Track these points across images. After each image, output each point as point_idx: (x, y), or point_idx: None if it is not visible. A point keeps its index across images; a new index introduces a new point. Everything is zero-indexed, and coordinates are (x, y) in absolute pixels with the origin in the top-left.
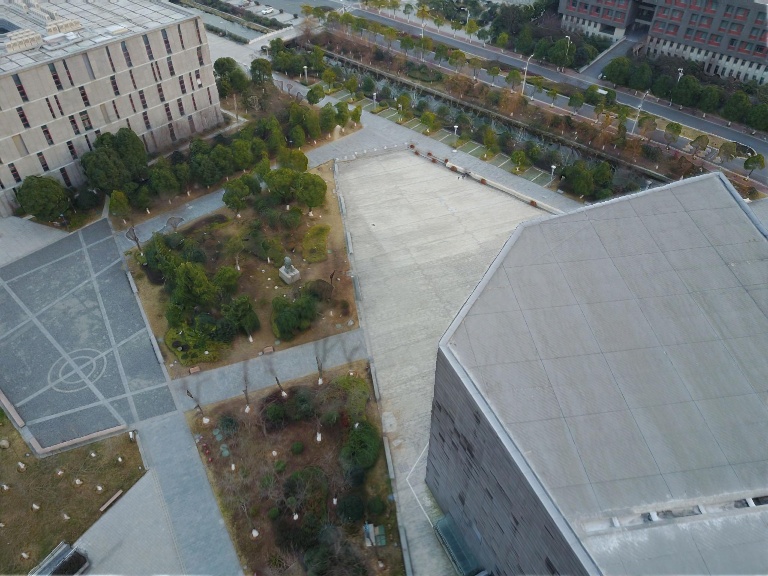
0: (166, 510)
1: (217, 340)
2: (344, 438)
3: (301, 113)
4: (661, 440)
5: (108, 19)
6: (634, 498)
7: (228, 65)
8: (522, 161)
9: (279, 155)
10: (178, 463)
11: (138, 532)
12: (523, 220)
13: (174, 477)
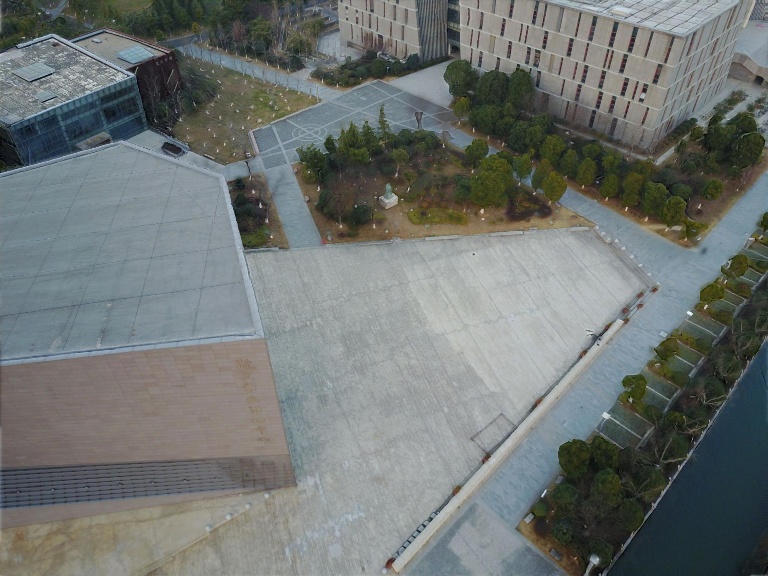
0: None
1: None
2: None
3: None
4: None
5: (650, 7)
6: None
7: (738, 122)
8: (633, 392)
9: None
10: (226, 174)
11: None
12: (498, 384)
13: None
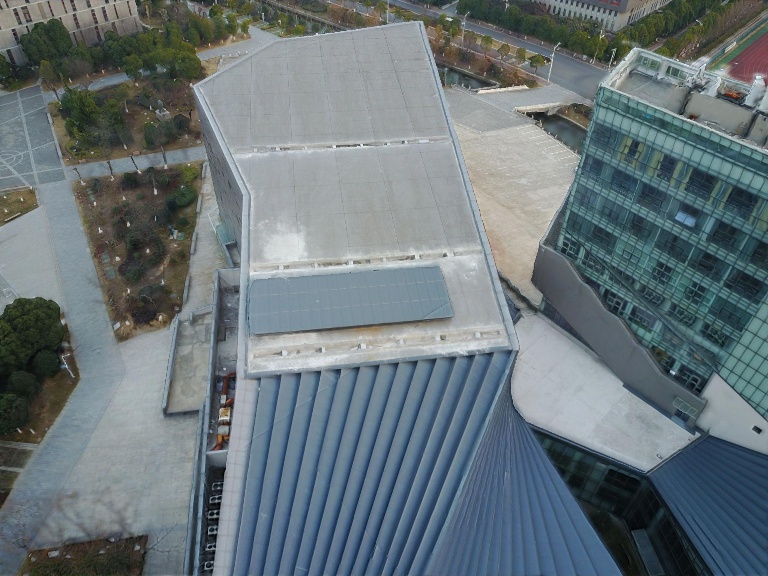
0: (47, 223)
1: (101, 146)
2: (172, 192)
3: (198, 21)
4: (300, 124)
5: None
6: (270, 142)
7: None
8: None
9: (171, 44)
10: (60, 203)
11: (27, 231)
12: None
13: (56, 209)
